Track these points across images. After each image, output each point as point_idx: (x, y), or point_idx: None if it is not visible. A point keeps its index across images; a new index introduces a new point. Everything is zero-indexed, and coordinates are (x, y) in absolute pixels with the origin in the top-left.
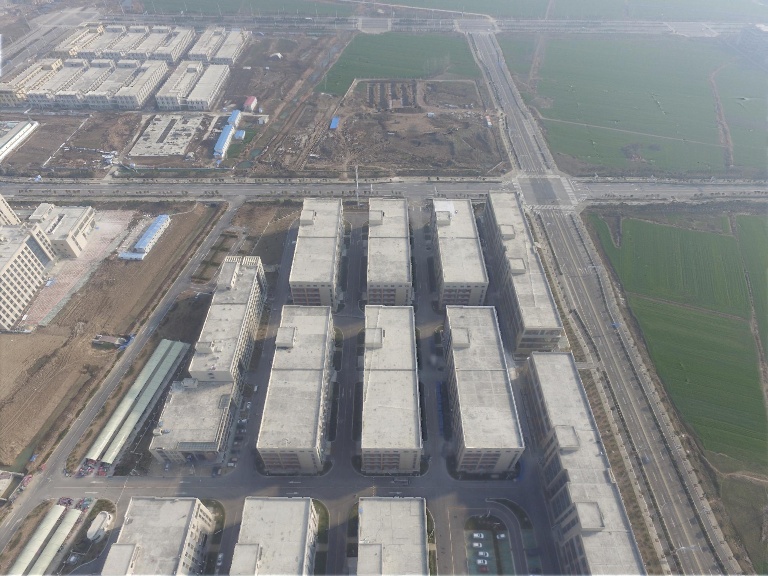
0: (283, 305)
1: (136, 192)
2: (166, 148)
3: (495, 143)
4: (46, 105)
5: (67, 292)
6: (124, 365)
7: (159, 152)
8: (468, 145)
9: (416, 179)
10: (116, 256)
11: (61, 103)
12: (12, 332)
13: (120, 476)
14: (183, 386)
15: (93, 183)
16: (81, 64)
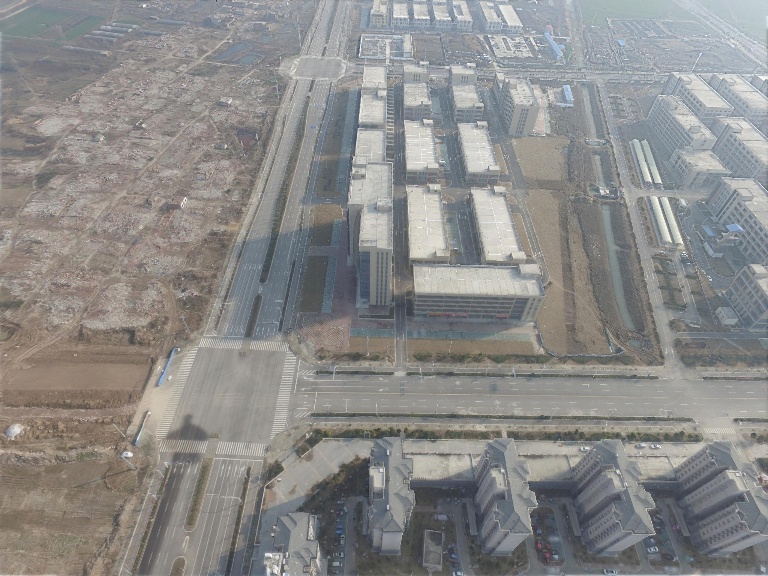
0: (716, 116)
1: (530, 74)
2: (518, 53)
3: (745, 57)
4: (404, 27)
5: (544, 120)
6: (619, 151)
7: (516, 55)
8: (729, 57)
9: (708, 74)
10: (553, 105)
11: (415, 25)
12: (534, 136)
13: (669, 190)
14: (686, 150)
15: (491, 70)
16: (406, 1)
